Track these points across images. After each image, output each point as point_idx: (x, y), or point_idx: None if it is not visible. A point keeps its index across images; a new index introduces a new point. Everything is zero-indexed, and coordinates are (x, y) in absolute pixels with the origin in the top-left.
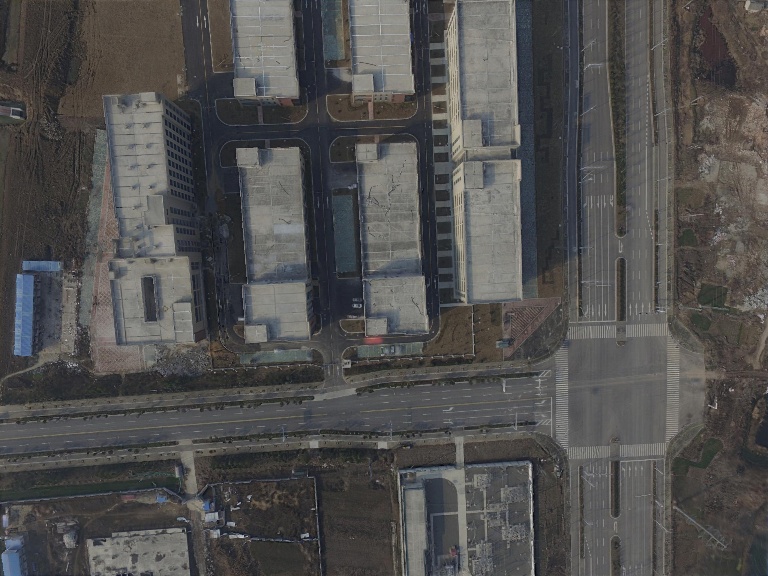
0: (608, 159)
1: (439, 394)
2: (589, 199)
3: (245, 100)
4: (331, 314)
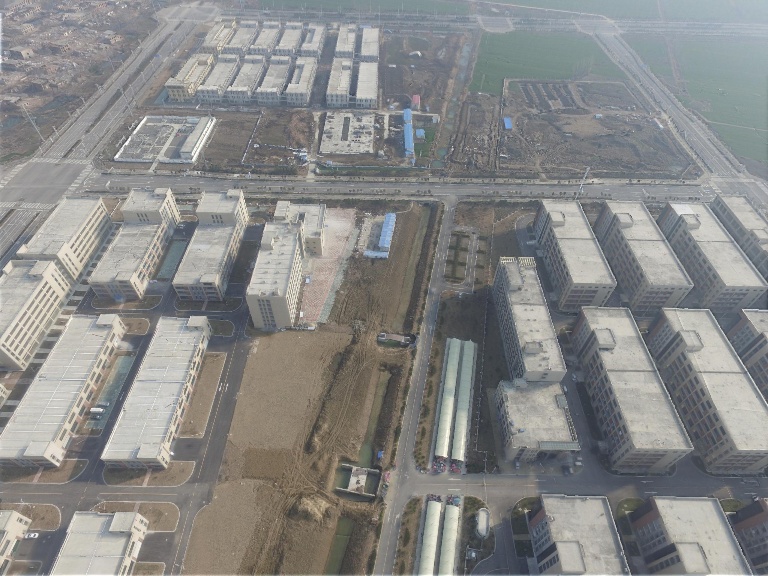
0: None
1: (152, 188)
2: None
3: None
4: None
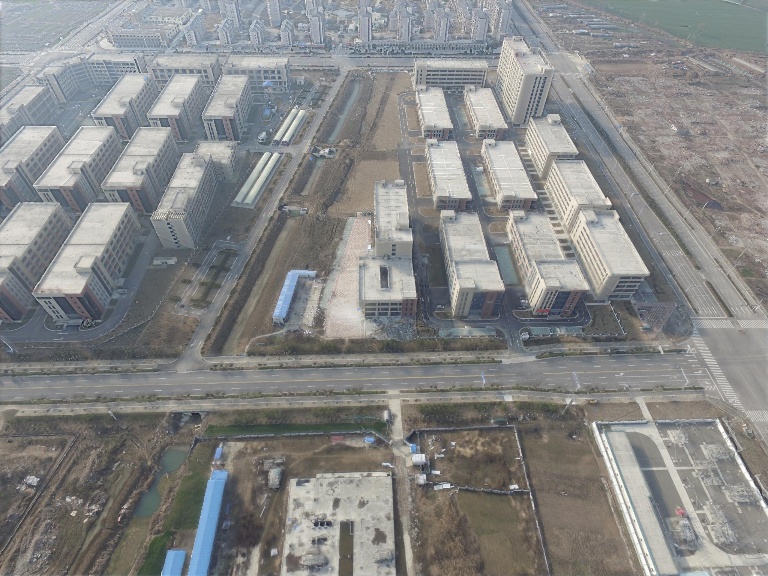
0: (666, 235)
1: (607, 362)
2: (665, 252)
3: (439, 203)
4: (505, 307)
